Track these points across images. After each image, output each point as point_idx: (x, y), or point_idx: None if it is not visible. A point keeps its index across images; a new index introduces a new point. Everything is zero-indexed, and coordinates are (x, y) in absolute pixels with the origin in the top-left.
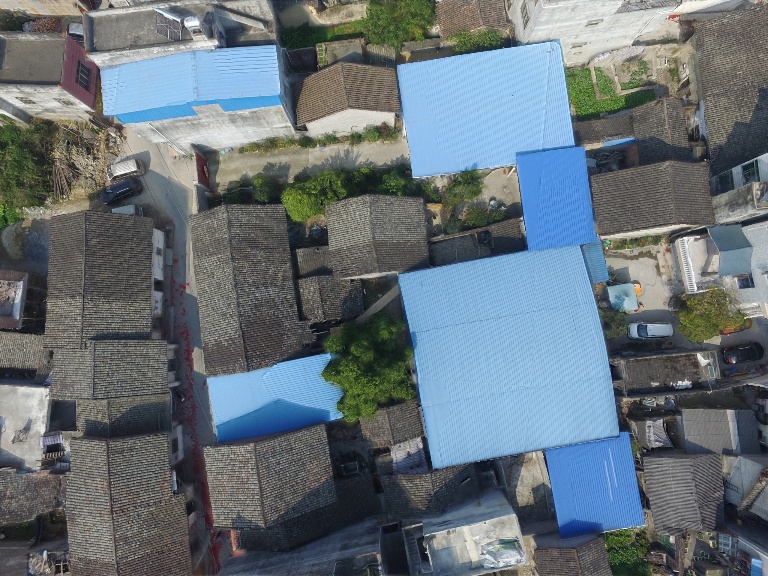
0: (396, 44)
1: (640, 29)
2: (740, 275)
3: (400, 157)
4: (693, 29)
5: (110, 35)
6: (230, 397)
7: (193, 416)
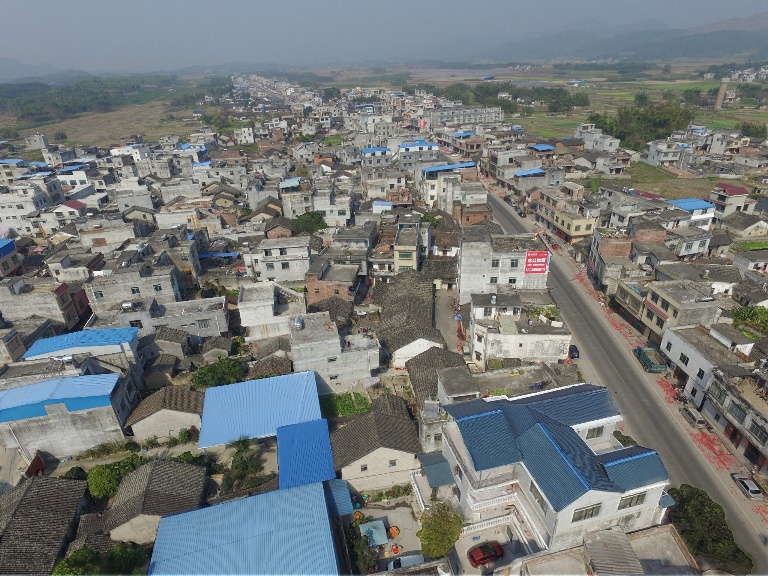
0: (214, 384)
1: (368, 365)
2: (452, 488)
3: (204, 452)
4: None
5: (14, 373)
6: None
7: None
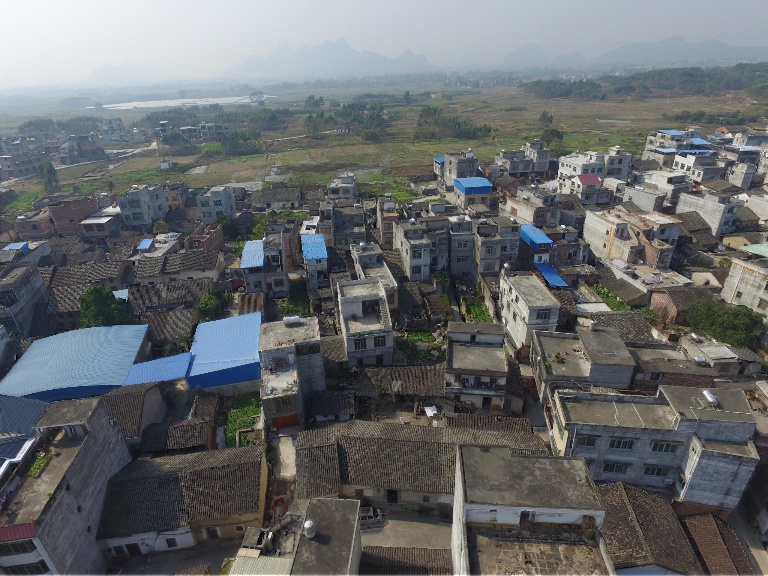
0: (281, 318)
1: None
2: None
3: None
4: (289, 486)
5: None
6: None
7: None
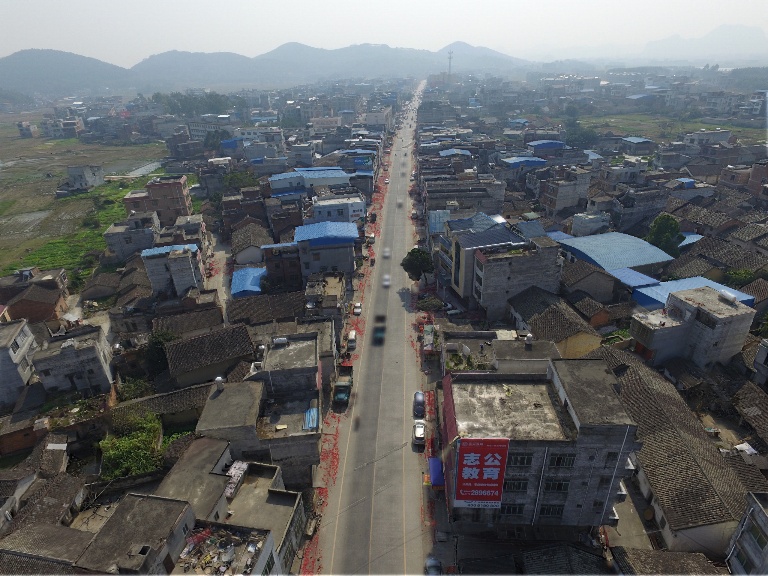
0: None
1: None
2: None
3: None
4: None
5: None
6: None
7: None
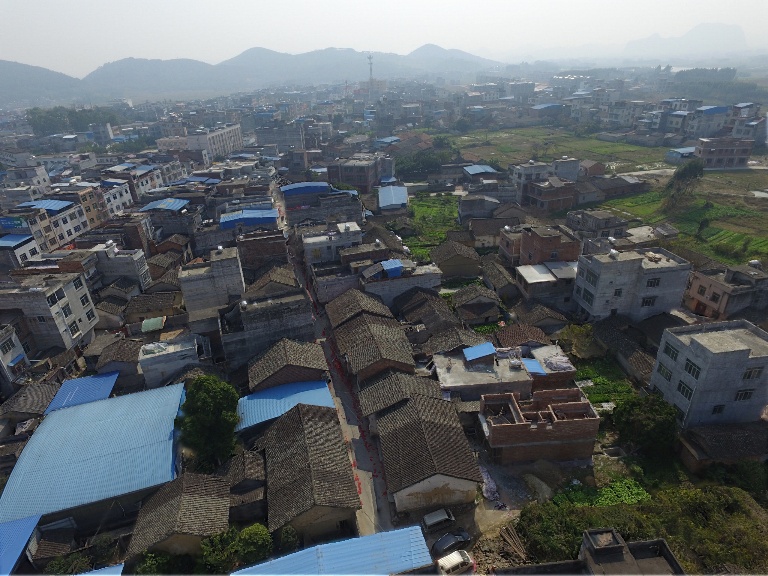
0: None
1: None
2: None
3: None
4: None
5: None
6: (317, 399)
7: (355, 403)
